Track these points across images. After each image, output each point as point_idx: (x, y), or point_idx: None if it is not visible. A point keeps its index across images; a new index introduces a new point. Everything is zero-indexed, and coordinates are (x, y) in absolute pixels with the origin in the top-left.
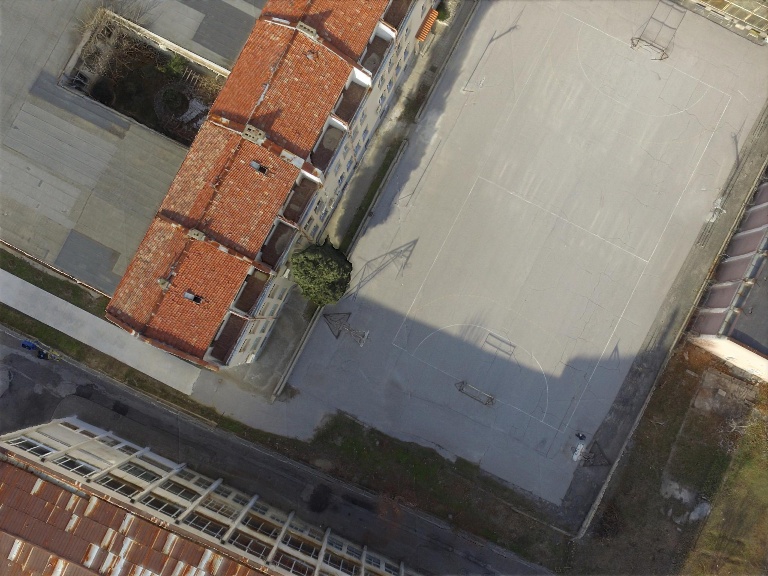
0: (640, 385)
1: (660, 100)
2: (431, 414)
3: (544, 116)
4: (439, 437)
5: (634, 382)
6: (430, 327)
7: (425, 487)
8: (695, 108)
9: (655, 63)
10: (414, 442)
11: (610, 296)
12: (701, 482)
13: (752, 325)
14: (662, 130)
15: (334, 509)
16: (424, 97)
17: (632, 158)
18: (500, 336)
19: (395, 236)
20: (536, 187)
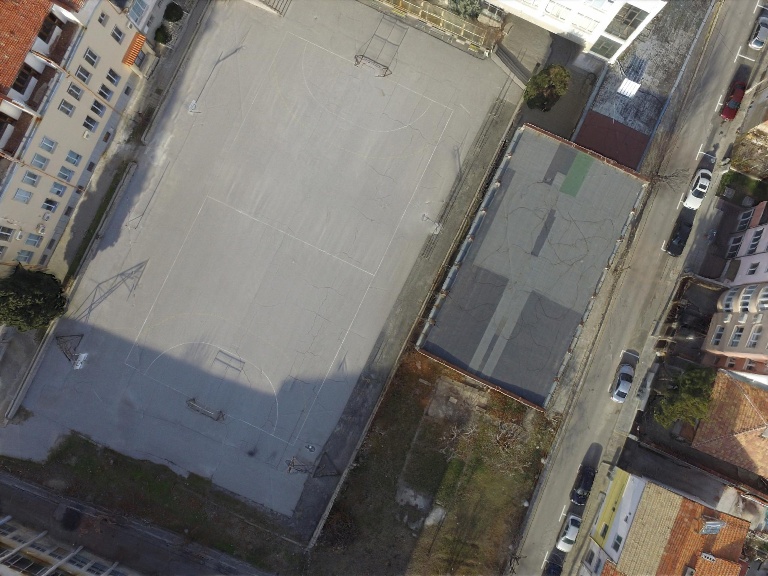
0: (368, 396)
1: (384, 116)
2: (163, 432)
3: (271, 135)
4: (171, 454)
5: (362, 393)
6: (162, 346)
7: (160, 503)
8: (419, 123)
9: (379, 80)
10: (147, 460)
11: (337, 310)
12: (435, 488)
13: (443, 336)
14: (387, 145)
15: (86, 527)
16: (149, 120)
17: (357, 174)
18: (230, 353)
19: (126, 257)
20: (264, 205)
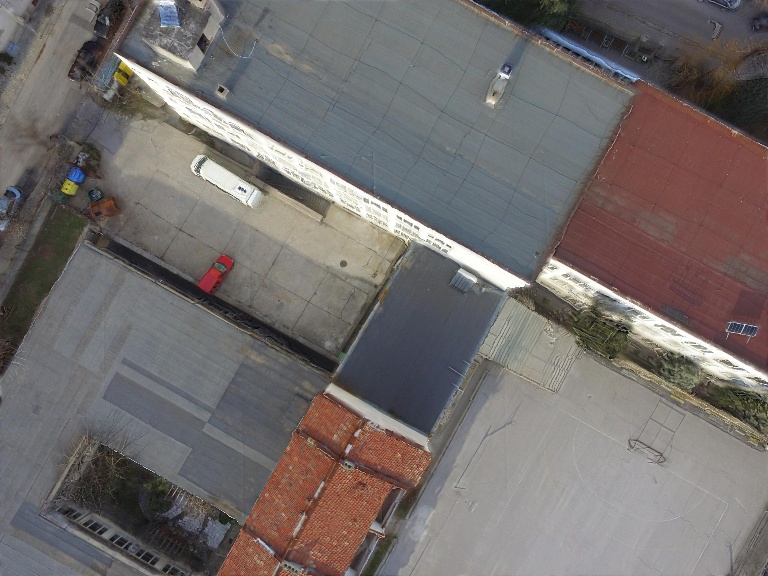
0: None
1: (655, 505)
2: None
3: (536, 517)
4: None
5: None
6: None
7: None
8: (690, 514)
9: (652, 466)
10: None
11: None
12: None
13: None
14: (656, 536)
15: None
16: (415, 498)
17: (624, 564)
18: None
19: None
20: None
